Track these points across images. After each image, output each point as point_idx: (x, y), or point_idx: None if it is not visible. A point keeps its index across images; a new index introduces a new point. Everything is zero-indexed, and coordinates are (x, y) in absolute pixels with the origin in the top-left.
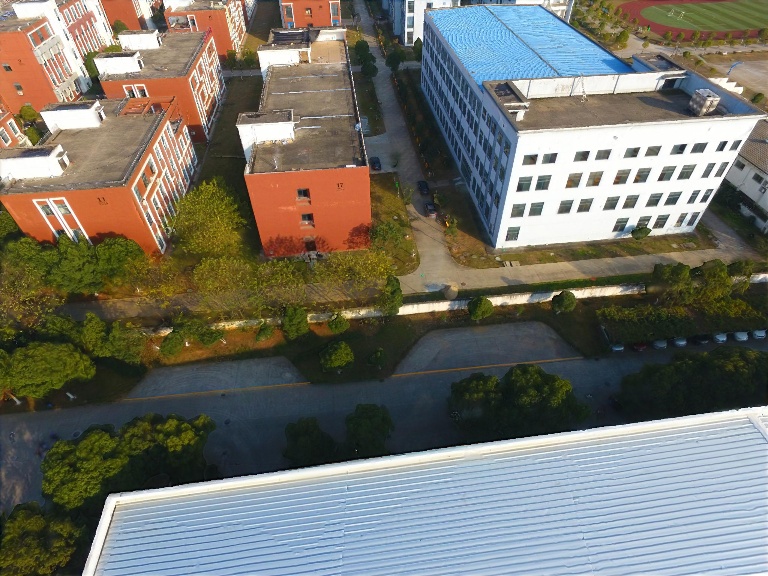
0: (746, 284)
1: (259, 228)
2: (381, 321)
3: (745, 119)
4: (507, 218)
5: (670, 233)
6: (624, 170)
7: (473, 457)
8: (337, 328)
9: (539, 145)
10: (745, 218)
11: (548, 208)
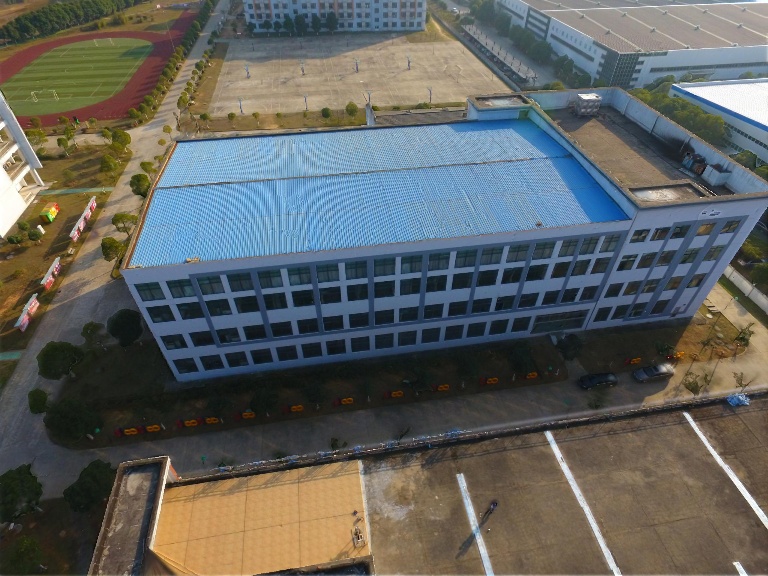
0: None
1: None
2: None
3: None
4: None
5: None
6: None
7: None
8: None
9: None
10: None
11: None
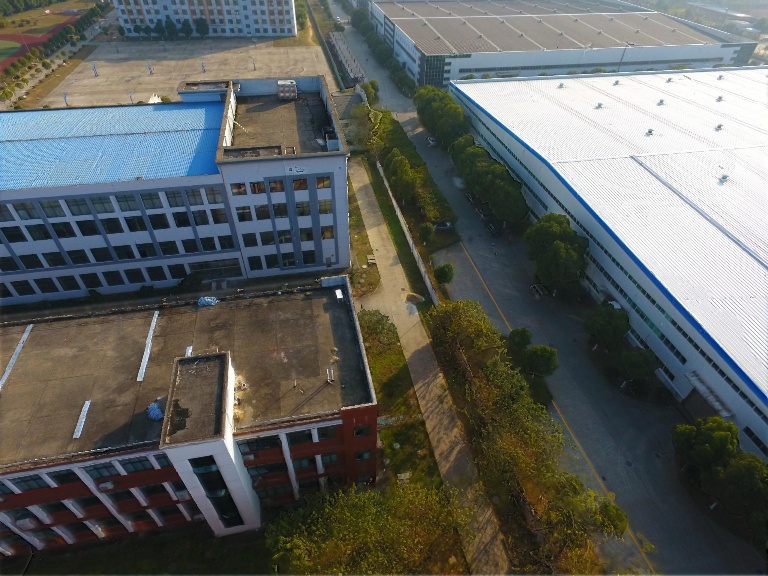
0: None
1: None
2: None
3: None
4: None
5: None
6: None
7: (630, 247)
8: None
9: None
10: None
11: None
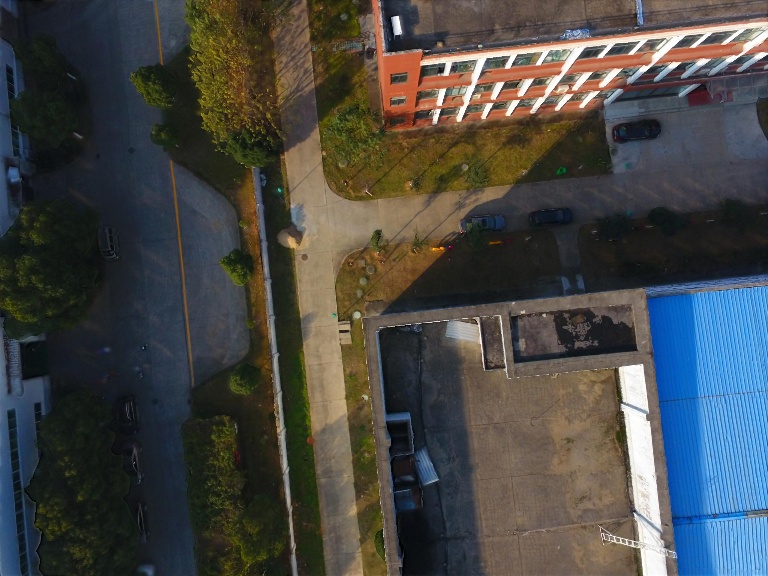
0: None
1: None
2: None
3: None
4: None
5: None
6: None
7: None
8: None
9: None
10: None
11: None
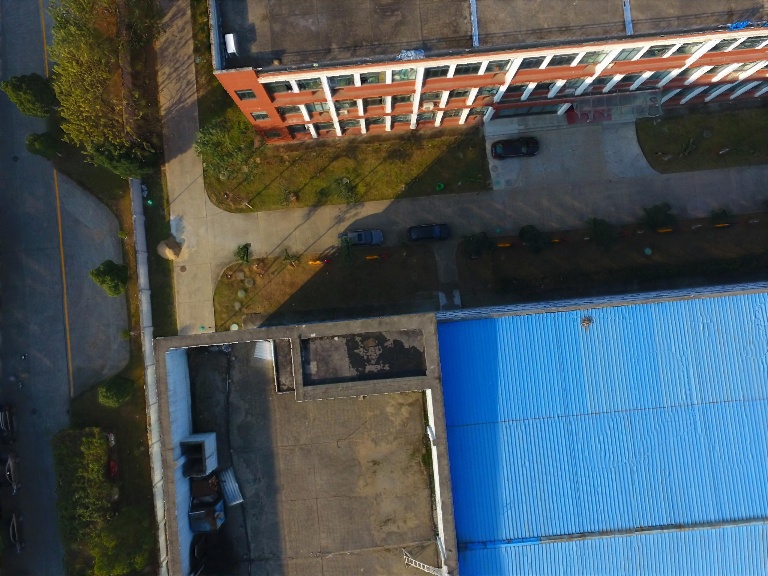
0: None
1: None
2: None
3: None
4: None
5: None
6: None
7: None
8: None
9: None
10: None
11: None
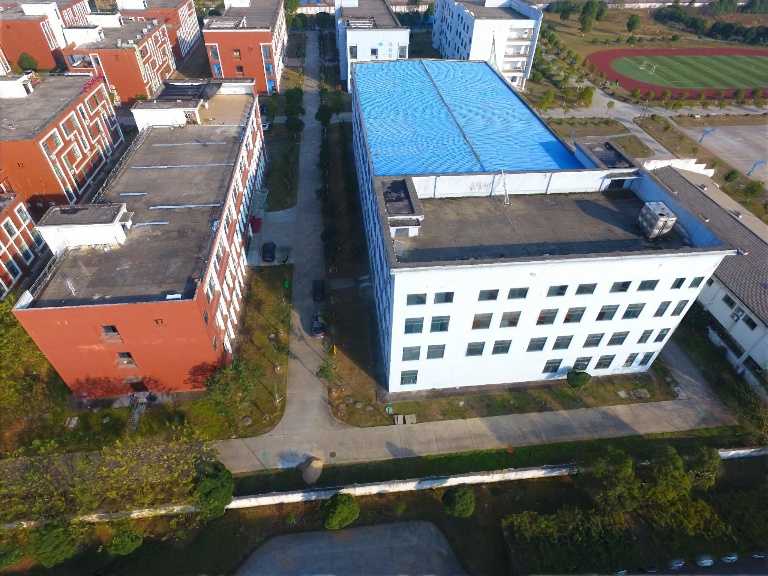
0: (710, 481)
1: (57, 369)
2: (203, 520)
3: (708, 255)
4: (398, 361)
5: (618, 373)
6: (549, 309)
7: None
8: (118, 551)
9: (426, 283)
10: (714, 347)
11: (452, 350)
